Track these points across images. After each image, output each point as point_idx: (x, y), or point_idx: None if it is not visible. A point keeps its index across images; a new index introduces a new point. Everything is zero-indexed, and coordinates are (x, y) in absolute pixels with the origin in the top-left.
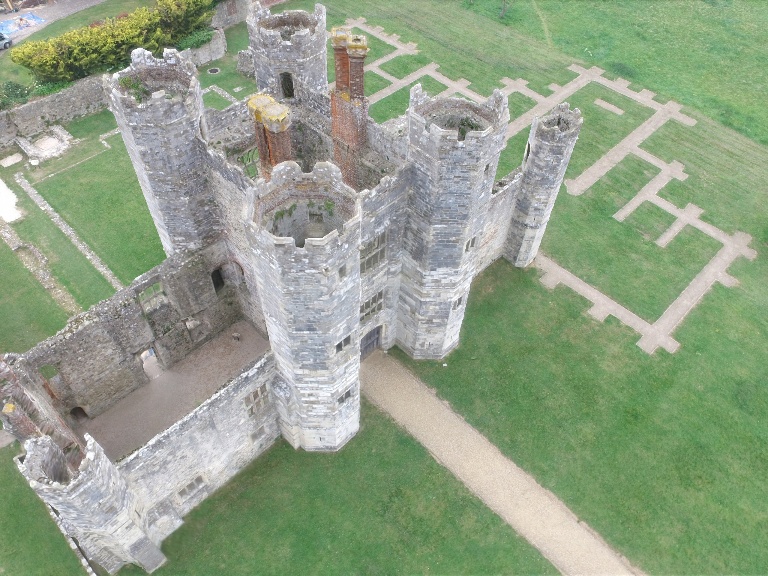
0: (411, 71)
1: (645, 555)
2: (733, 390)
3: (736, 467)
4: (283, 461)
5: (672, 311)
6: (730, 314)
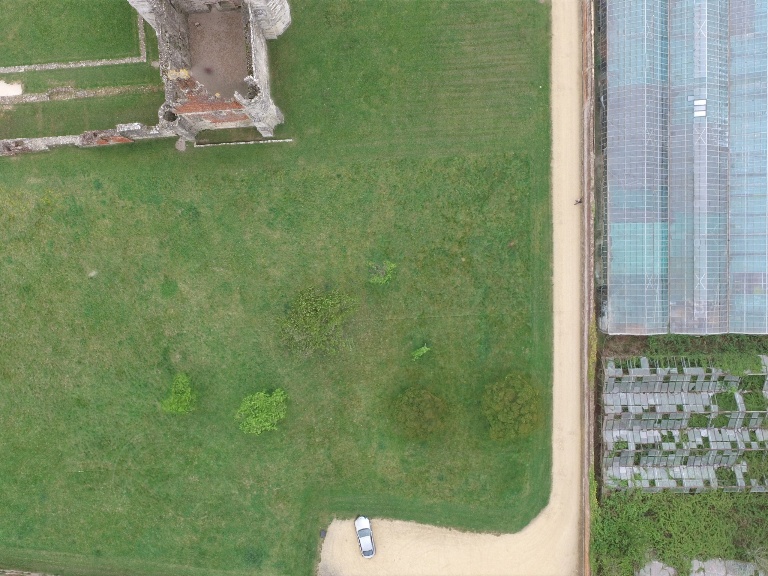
0: None
1: None
2: None
3: None
4: (278, 48)
5: None
6: None
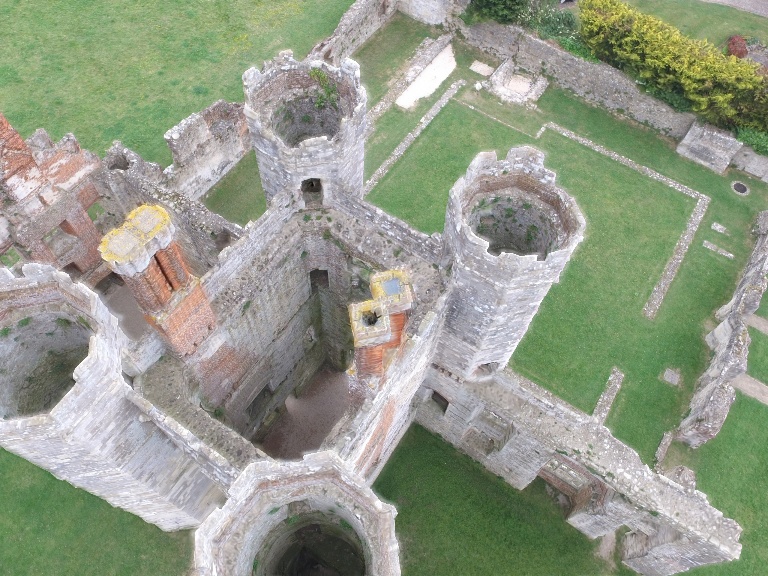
0: None
1: None
2: None
3: None
4: None
5: None
6: None
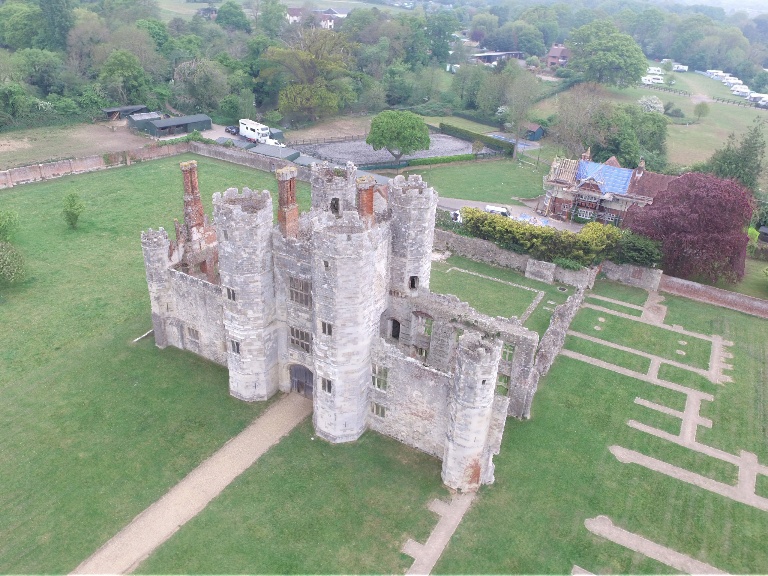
0: (679, 382)
1: (148, 570)
2: None
3: None
4: (222, 376)
5: None
6: None
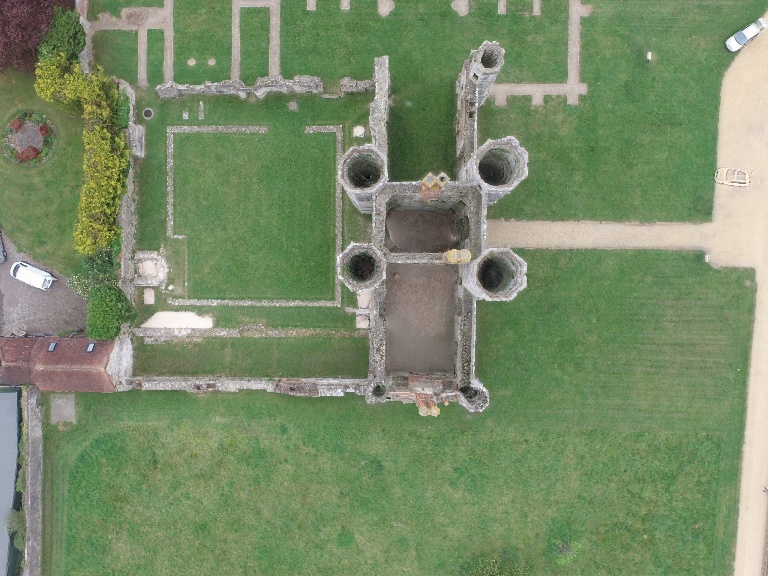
0: None
1: (633, 214)
2: (625, 94)
3: (646, 139)
4: None
5: (571, 63)
6: (599, 39)
